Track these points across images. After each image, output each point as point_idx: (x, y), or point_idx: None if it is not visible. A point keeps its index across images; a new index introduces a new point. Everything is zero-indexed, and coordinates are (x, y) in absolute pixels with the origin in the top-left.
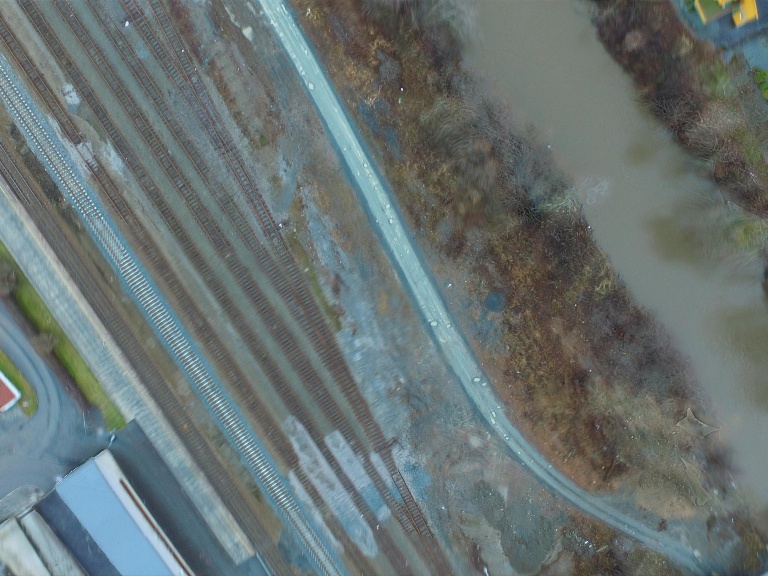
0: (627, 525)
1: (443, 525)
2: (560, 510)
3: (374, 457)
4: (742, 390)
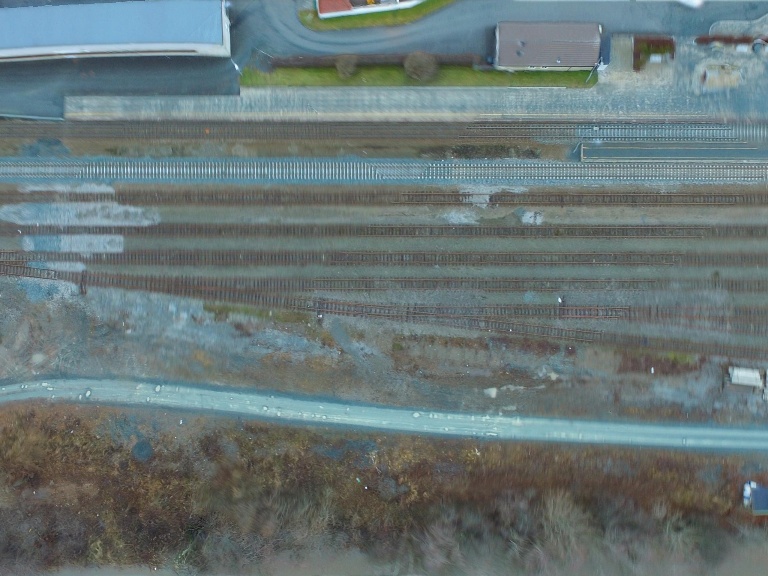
0: None
1: None
2: None
3: (81, 267)
4: None
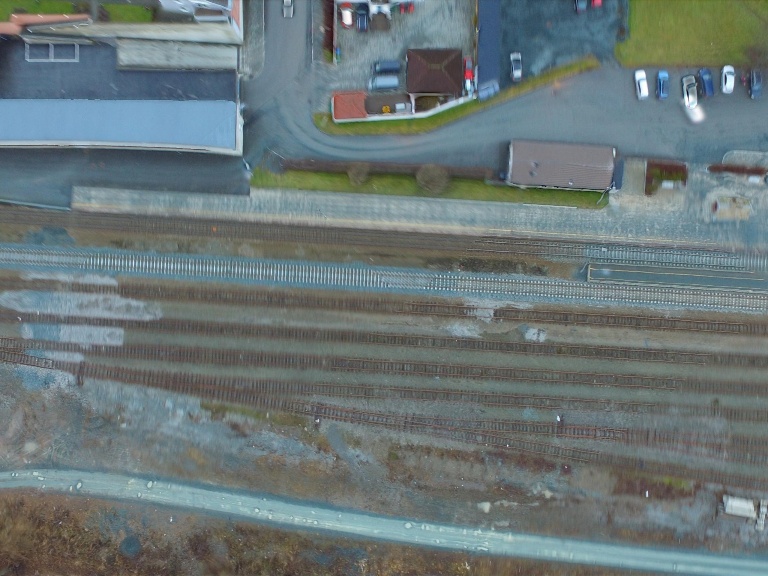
0: None
1: None
2: None
3: (79, 357)
4: None
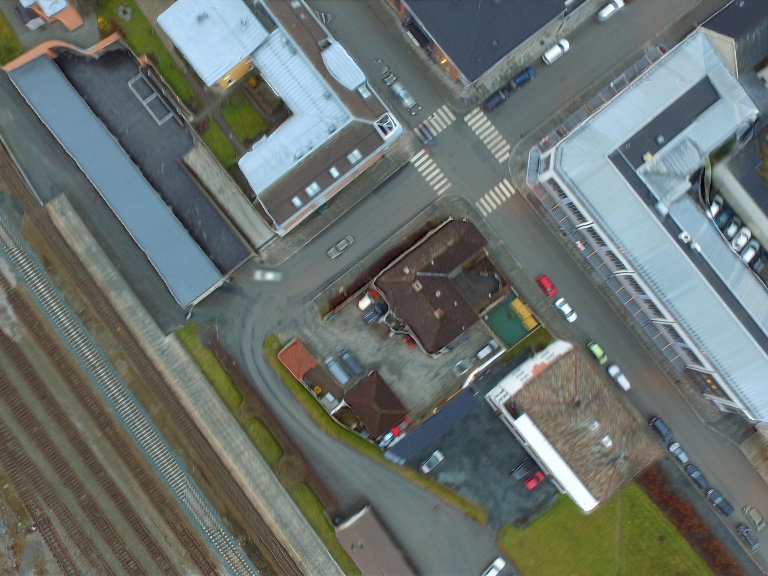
0: None
1: None
2: None
3: None
4: None
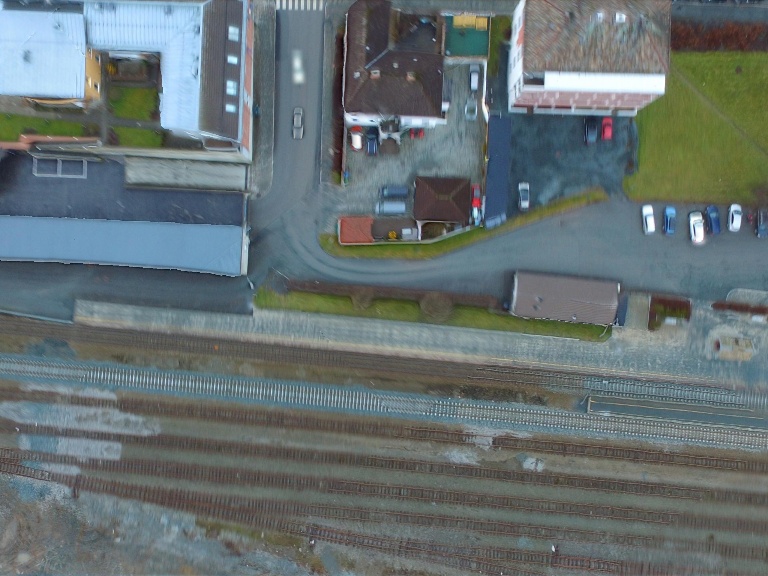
0: None
1: None
2: None
3: (76, 470)
4: None
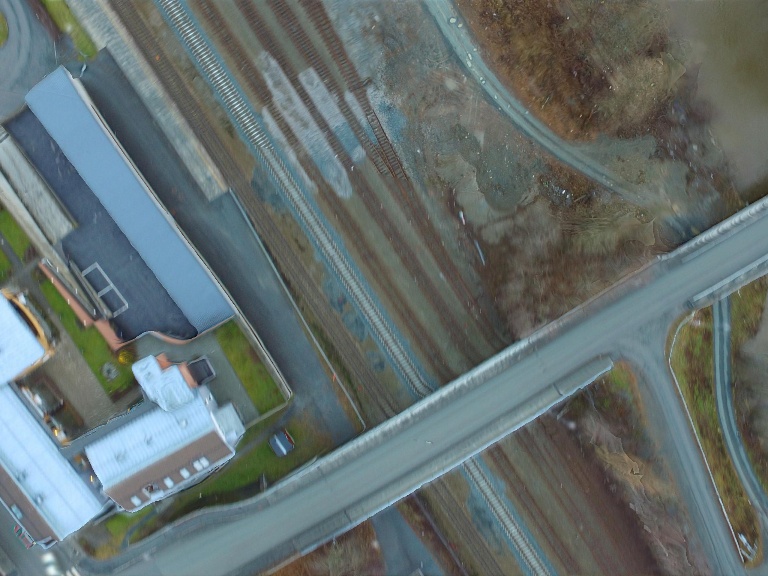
0: (605, 176)
1: (418, 168)
2: (537, 158)
3: (349, 96)
4: (721, 36)
